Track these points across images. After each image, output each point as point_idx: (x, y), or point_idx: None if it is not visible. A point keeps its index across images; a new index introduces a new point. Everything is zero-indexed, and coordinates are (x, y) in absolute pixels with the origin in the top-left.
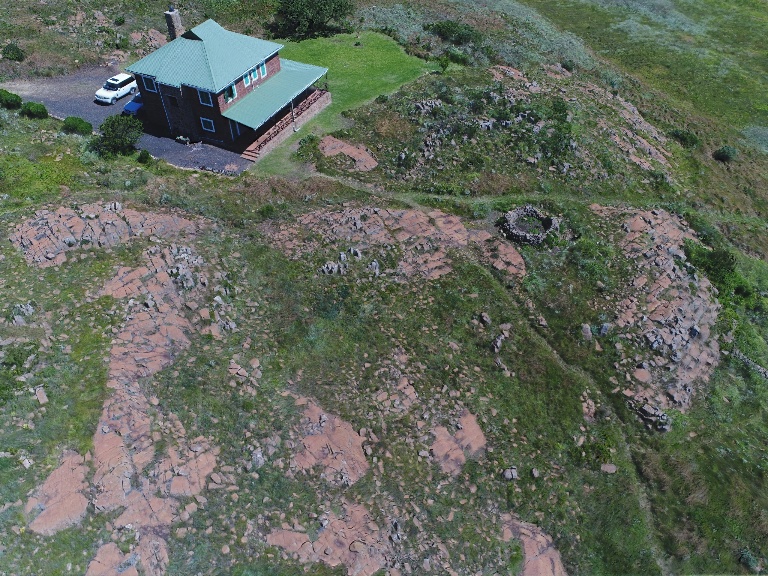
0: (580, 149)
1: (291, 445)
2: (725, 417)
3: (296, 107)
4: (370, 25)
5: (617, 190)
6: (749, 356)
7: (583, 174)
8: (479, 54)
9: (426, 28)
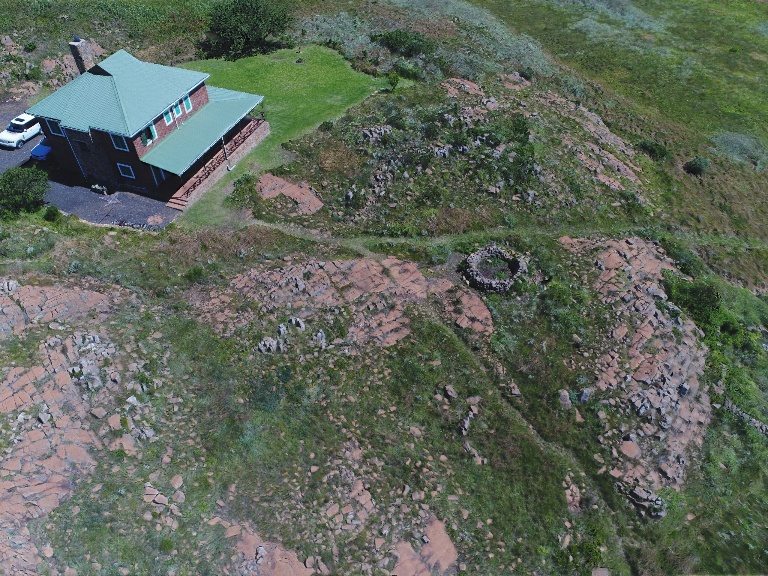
0: (545, 173)
1: None
2: (724, 490)
3: (229, 141)
4: (313, 38)
5: (587, 217)
6: (743, 408)
7: (550, 202)
8: (431, 66)
9: (373, 39)
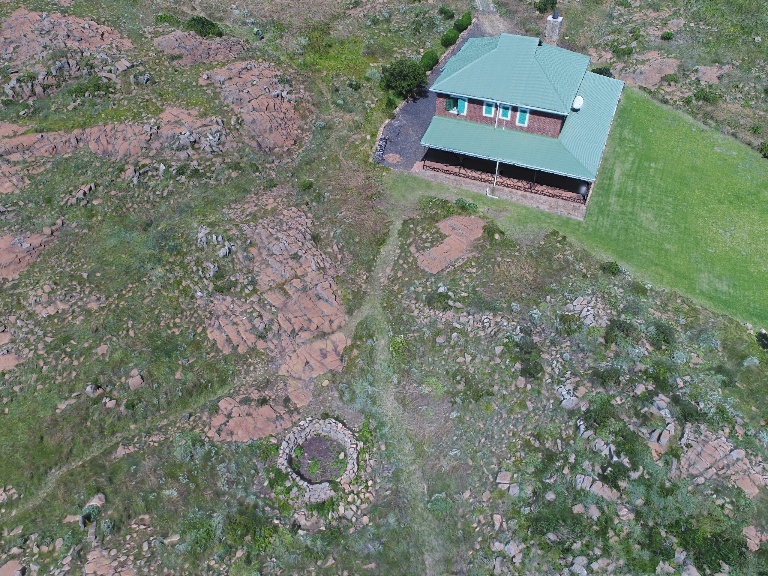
0: None
1: (5, 227)
2: None
3: None
4: None
5: None
6: None
7: None
8: None
9: None
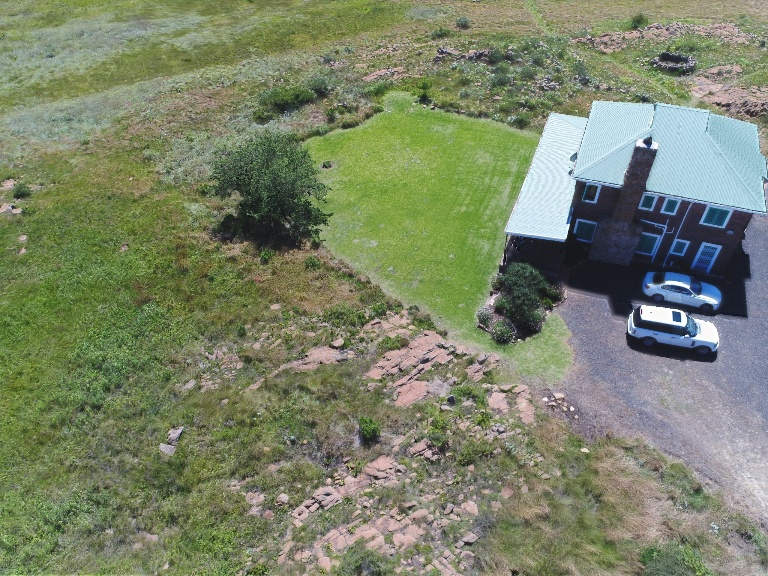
0: None
1: None
2: None
3: None
4: None
5: None
6: None
7: None
8: None
9: (262, 120)
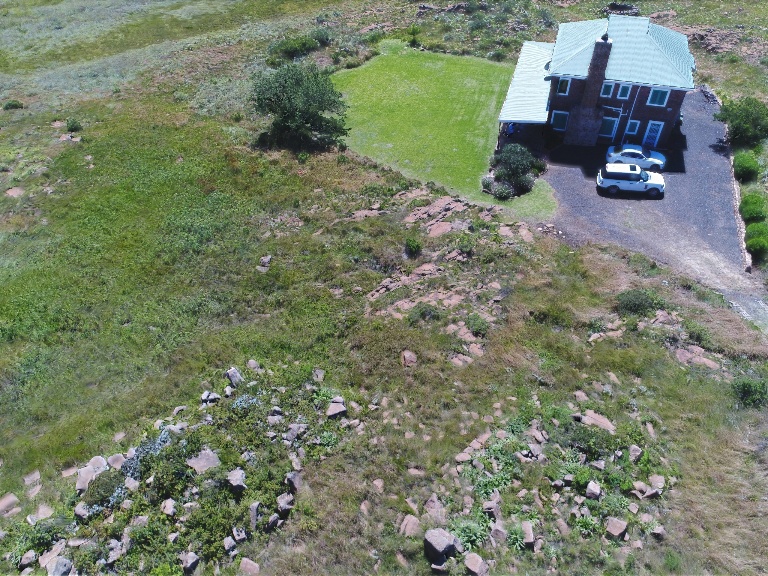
0: None
1: None
2: None
3: None
4: None
5: None
6: None
7: None
8: None
9: (275, 65)
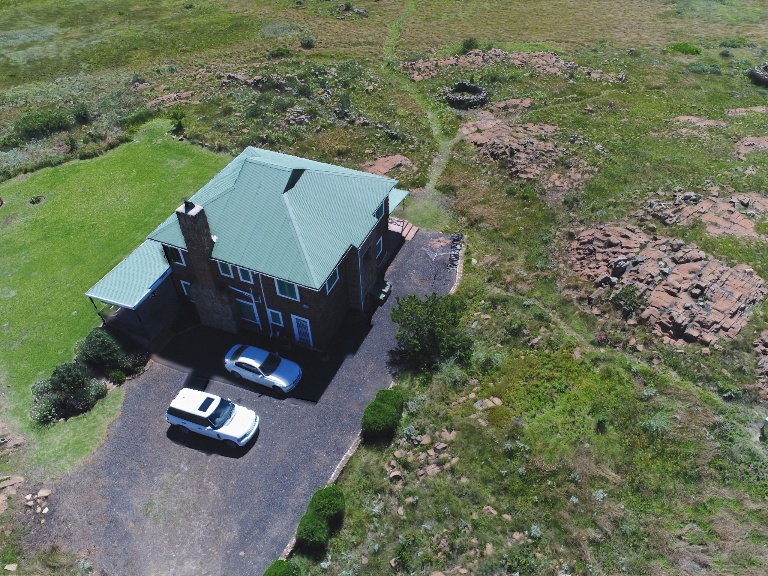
0: None
1: None
2: None
3: None
4: None
5: None
6: None
7: None
8: None
9: (7, 147)
